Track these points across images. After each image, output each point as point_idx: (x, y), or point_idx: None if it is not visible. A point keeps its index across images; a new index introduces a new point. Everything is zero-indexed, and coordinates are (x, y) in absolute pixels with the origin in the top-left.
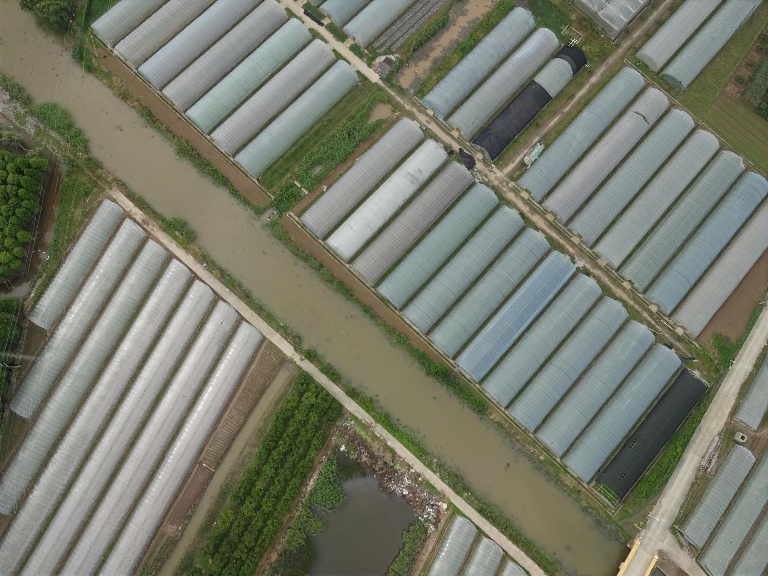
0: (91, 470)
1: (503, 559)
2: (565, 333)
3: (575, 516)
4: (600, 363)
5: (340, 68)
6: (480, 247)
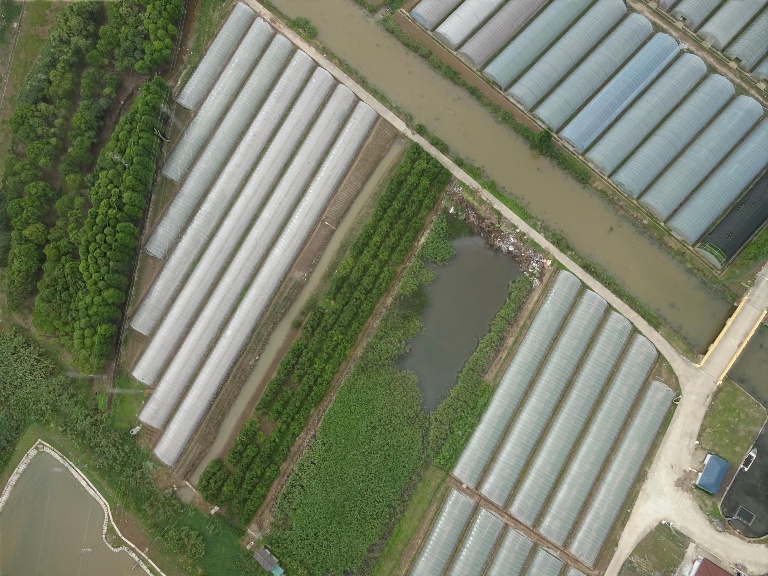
0: (230, 223)
1: (607, 311)
2: (669, 107)
3: (680, 277)
4: (705, 134)
5: None
6: (583, 29)
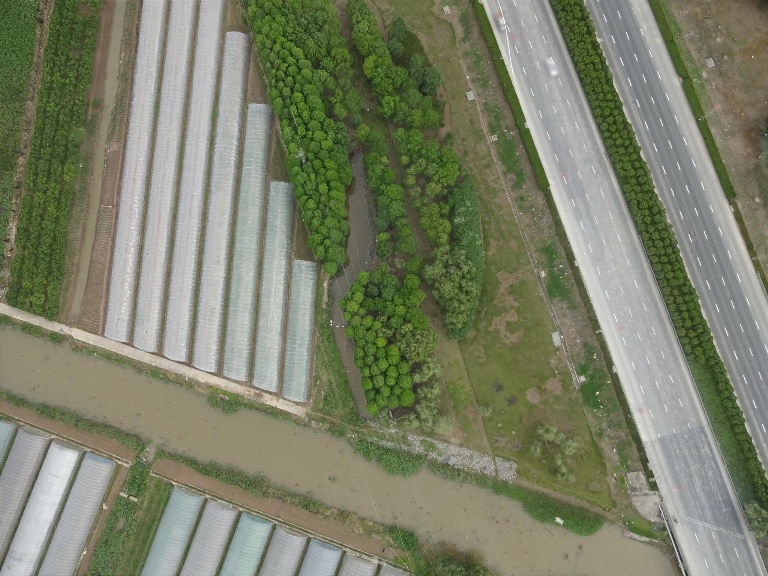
0: (197, 164)
1: None
2: None
3: None
4: None
5: None
6: None
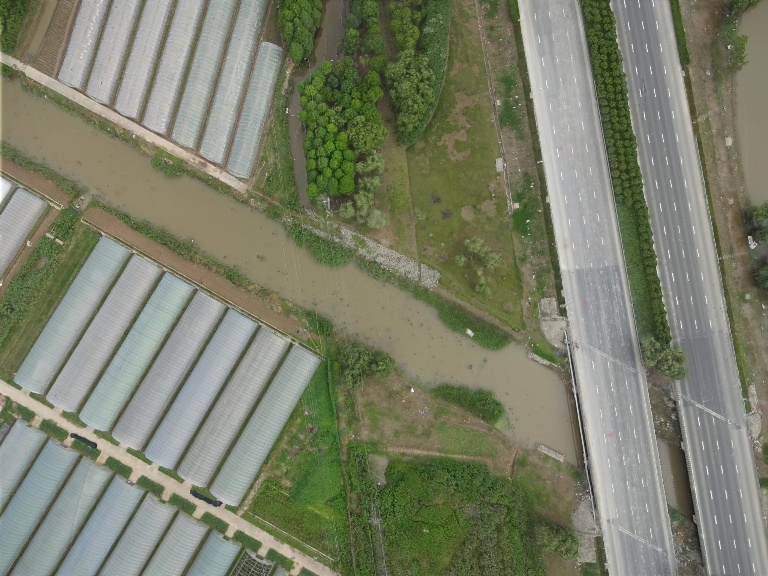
0: None
1: None
2: None
3: None
4: None
5: (32, 380)
6: None
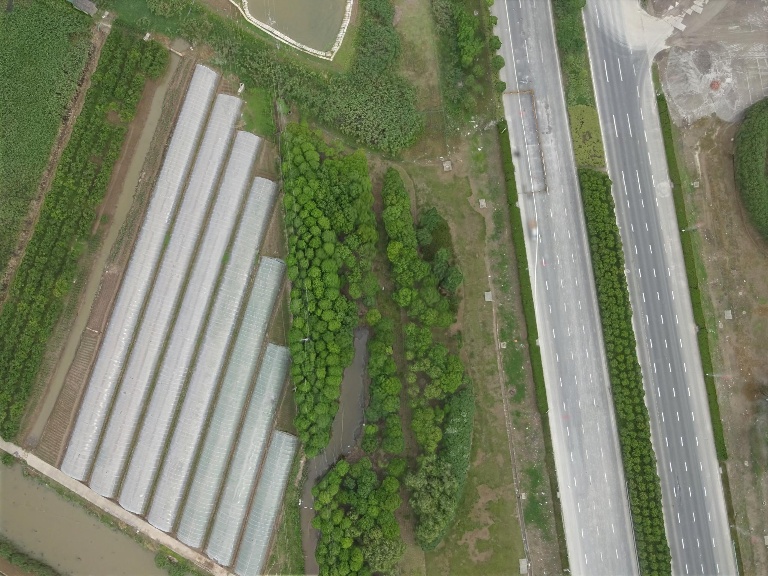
0: (197, 308)
1: None
2: None
3: None
4: None
5: None
6: None
